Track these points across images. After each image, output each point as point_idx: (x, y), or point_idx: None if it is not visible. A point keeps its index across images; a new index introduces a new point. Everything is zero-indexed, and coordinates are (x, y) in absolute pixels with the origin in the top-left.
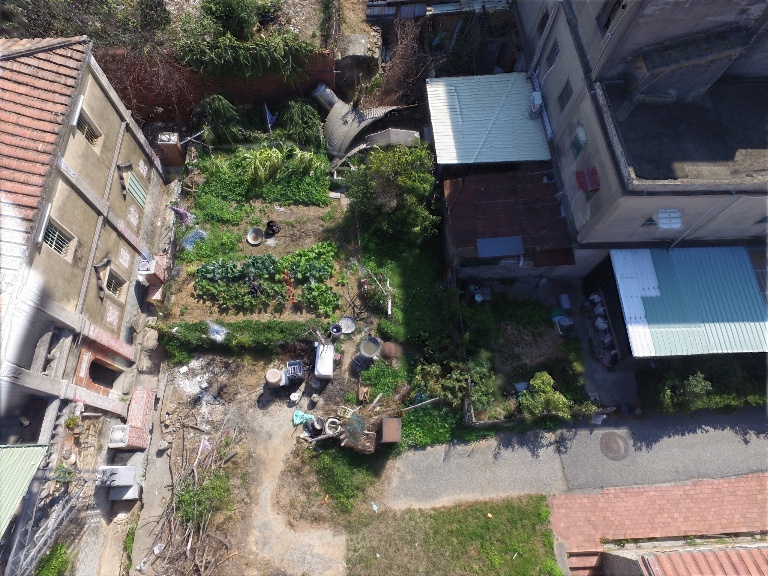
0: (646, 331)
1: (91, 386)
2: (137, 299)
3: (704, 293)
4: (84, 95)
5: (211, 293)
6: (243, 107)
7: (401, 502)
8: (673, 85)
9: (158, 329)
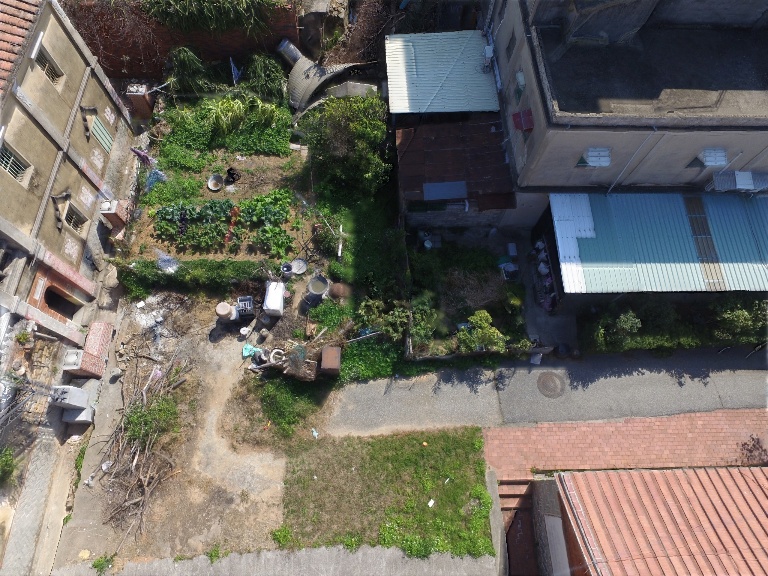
0: (579, 269)
1: (46, 310)
2: (100, 239)
3: (638, 236)
4: (44, 33)
5: (170, 234)
6: (210, 62)
7: (341, 430)
8: (603, 27)
9: (115, 263)
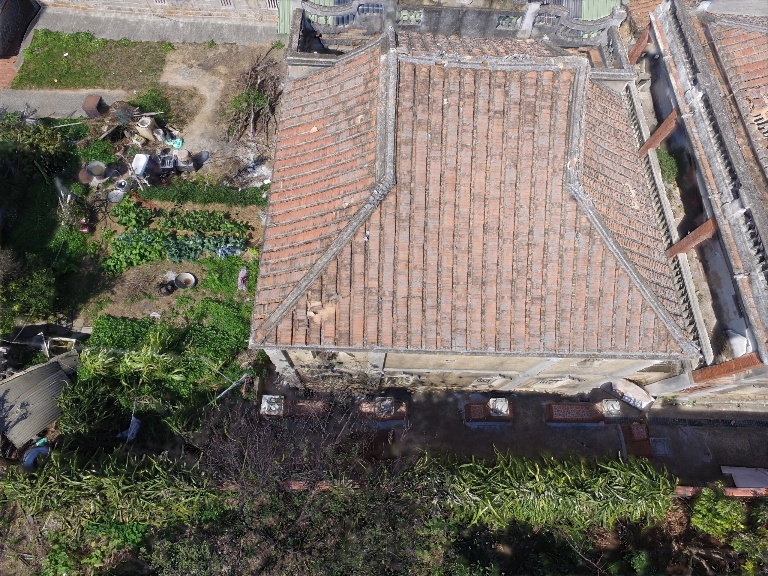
0: None
1: None
2: None
3: None
4: None
5: None
6: None
7: (116, 93)
8: None
9: None
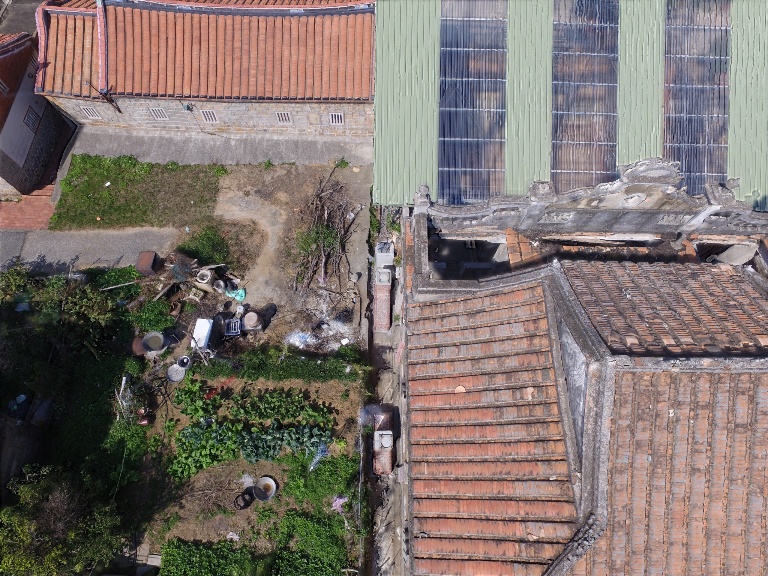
0: None
1: None
2: None
3: None
4: None
5: None
6: None
7: (166, 232)
8: None
9: None
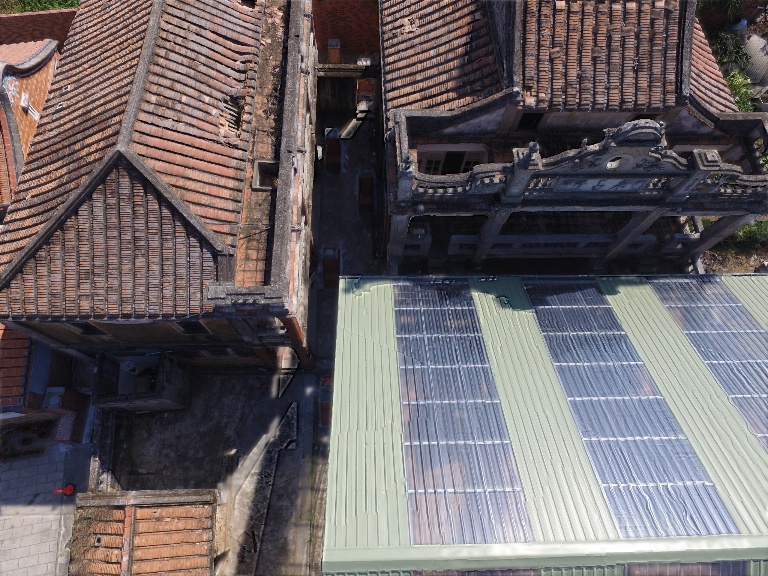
0: None
1: None
2: None
3: None
4: None
5: None
6: None
7: None
8: None
9: None
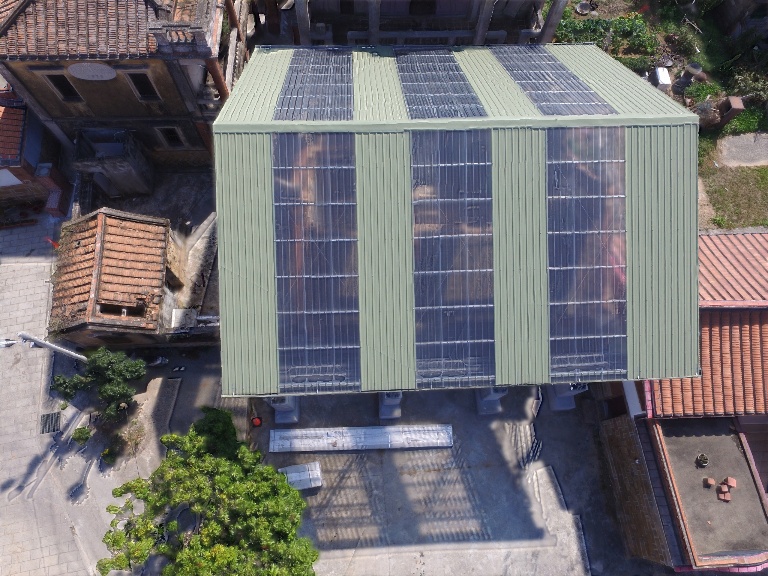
0: None
1: None
2: None
3: None
4: None
5: None
6: None
7: (733, 163)
8: None
9: None
